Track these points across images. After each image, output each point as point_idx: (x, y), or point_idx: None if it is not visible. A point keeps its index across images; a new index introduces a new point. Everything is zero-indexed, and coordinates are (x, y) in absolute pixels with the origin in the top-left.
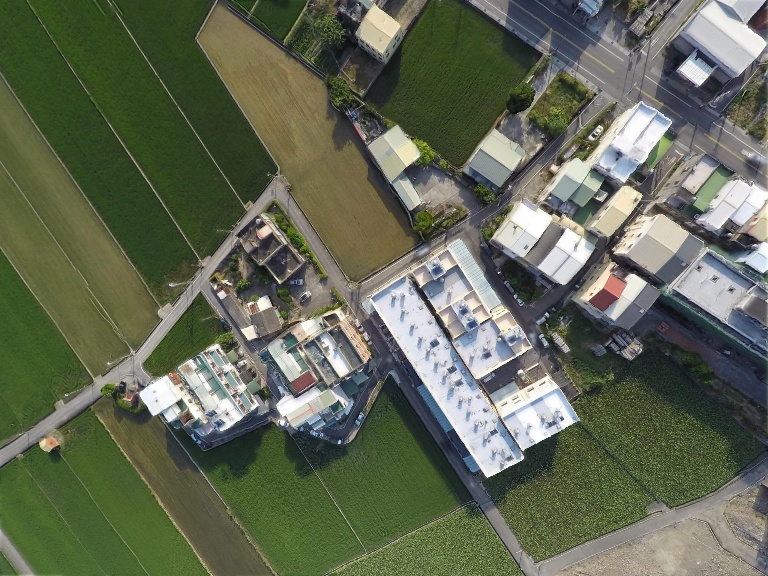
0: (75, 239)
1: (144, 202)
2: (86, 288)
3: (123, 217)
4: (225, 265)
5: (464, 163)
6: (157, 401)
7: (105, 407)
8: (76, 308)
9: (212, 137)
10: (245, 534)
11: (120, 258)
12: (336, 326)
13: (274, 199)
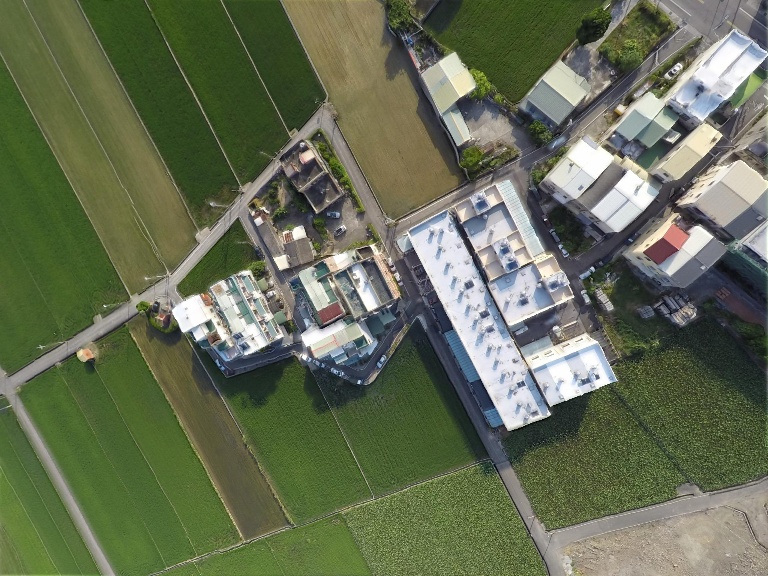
0: (125, 157)
1: (193, 124)
2: (131, 206)
3: (172, 138)
4: (264, 192)
5: (522, 98)
6: (188, 318)
7: (139, 325)
8: (120, 226)
9: (264, 60)
10: (258, 464)
11: (165, 179)
12: (369, 258)
13: (319, 127)
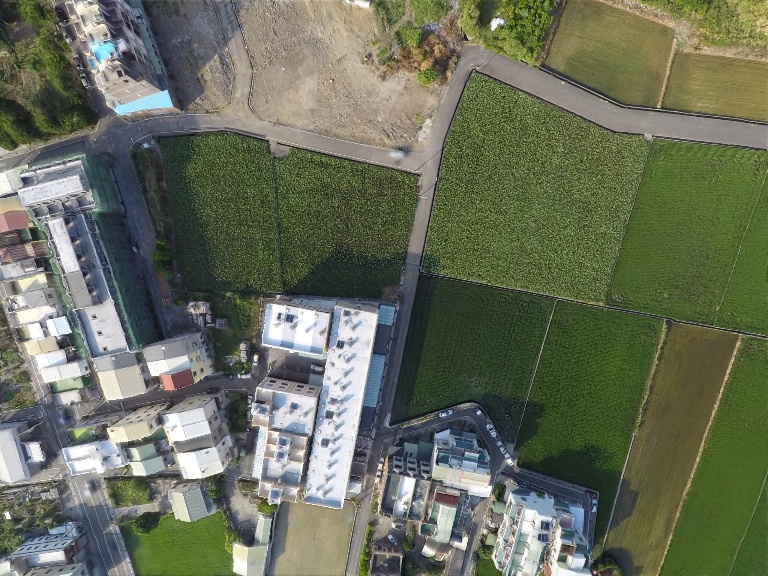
0: None
1: None
2: None
3: None
4: None
5: None
6: None
7: None
8: None
9: None
10: None
11: None
12: None
13: None
